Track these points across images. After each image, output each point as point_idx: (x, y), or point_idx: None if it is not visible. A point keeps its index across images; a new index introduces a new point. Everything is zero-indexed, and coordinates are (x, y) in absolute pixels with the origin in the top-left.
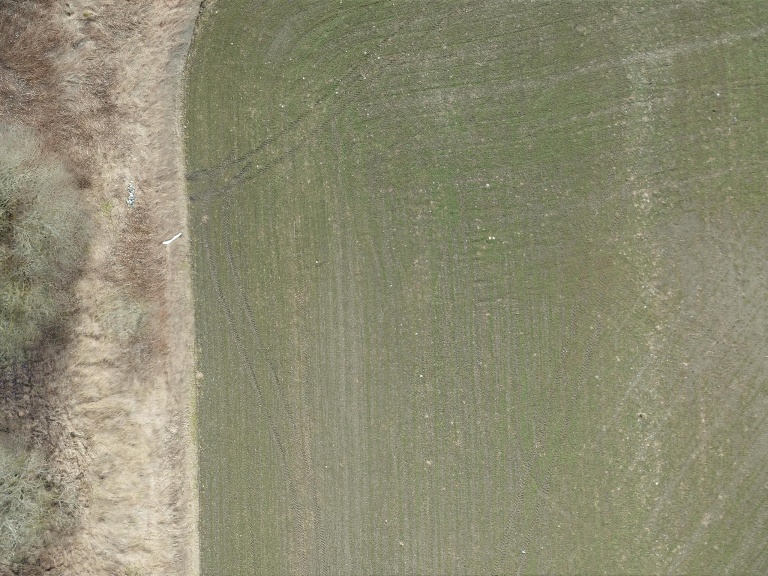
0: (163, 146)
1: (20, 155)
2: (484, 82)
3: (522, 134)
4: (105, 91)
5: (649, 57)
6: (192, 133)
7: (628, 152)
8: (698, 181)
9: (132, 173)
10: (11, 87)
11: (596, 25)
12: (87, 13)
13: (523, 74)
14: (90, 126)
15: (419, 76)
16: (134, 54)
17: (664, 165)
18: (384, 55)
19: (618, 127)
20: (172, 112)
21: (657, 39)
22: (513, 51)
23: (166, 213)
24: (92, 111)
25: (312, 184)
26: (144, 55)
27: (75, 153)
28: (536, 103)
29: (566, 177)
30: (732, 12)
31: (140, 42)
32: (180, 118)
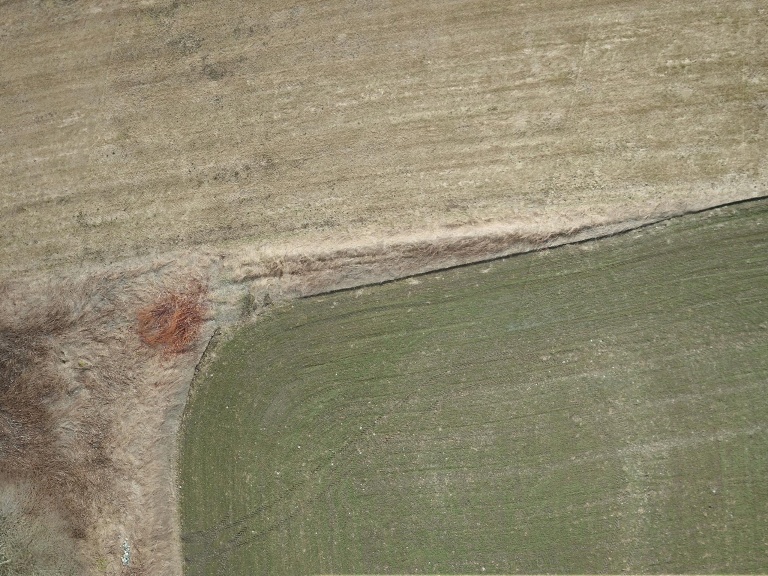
0: (158, 505)
1: (15, 496)
2: (480, 467)
3: (518, 521)
4: (100, 443)
5: (645, 450)
6: (187, 494)
7: (624, 543)
8: (694, 575)
9: (127, 531)
10: (6, 430)
11: (592, 416)
12: (82, 363)
13: (519, 461)
14: (85, 476)
15: (414, 456)
16: (129, 410)
17: (660, 558)
18: (379, 432)
19: (614, 519)
20: (167, 471)
21: (653, 432)
22: (509, 438)
23: (161, 573)
24: (87, 460)
25: (307, 553)
26: (139, 412)
27: (70, 500)
28: (532, 491)
29: (562, 565)
30: (728, 409)
31: (135, 398)
32: (175, 478)
